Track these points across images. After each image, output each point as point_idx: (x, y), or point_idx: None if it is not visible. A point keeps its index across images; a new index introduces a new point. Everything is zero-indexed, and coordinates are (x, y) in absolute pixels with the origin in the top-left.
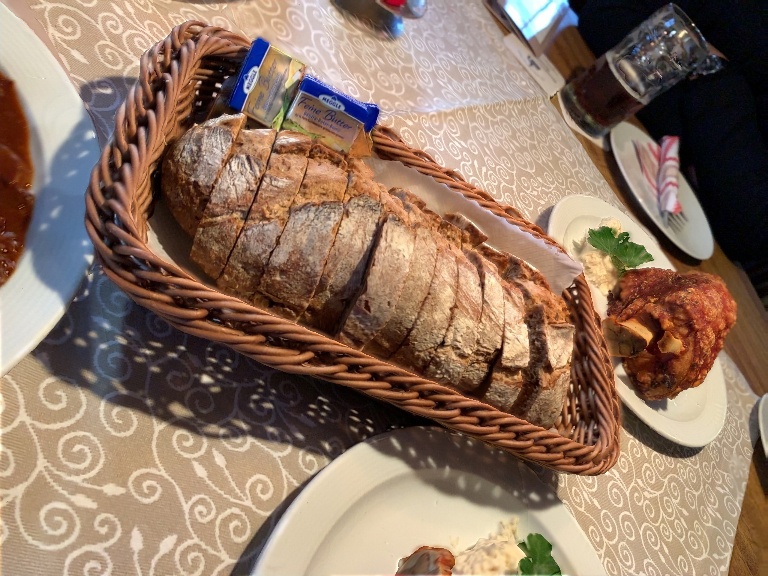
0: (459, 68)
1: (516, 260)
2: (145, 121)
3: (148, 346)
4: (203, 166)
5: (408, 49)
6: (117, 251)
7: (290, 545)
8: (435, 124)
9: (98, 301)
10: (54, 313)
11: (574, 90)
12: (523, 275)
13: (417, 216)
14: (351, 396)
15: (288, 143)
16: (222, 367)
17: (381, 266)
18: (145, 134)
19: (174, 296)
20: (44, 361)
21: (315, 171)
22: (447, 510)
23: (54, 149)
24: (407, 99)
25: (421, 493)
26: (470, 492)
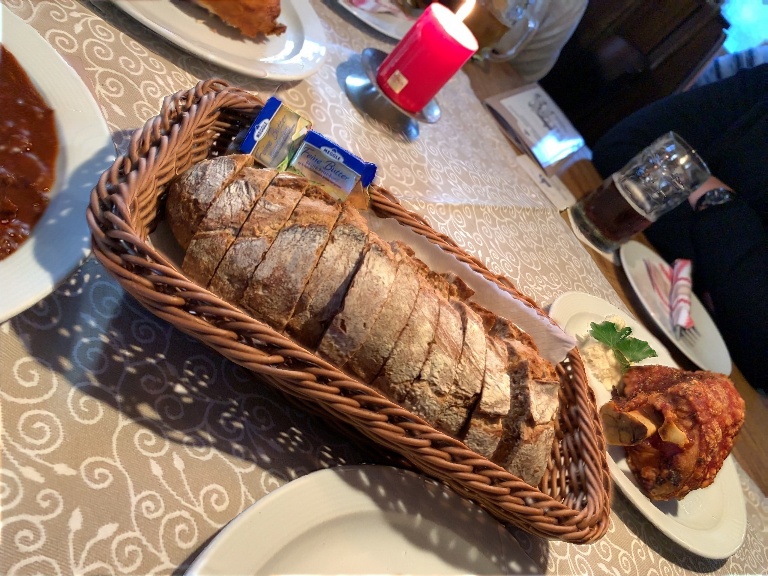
0: (470, 174)
1: (505, 321)
2: (158, 143)
3: (129, 348)
4: (205, 187)
5: (422, 152)
6: (109, 235)
7: (234, 552)
8: (442, 213)
9: (89, 301)
10: (42, 289)
11: (583, 207)
12: (510, 334)
13: (403, 258)
14: (326, 434)
15: (286, 178)
16: (198, 381)
17: (360, 288)
18: (156, 151)
19: (155, 282)
20: (25, 341)
21: (307, 203)
22: (416, 564)
23: (76, 164)
24: (416, 190)
25: (388, 539)
26: (443, 550)
